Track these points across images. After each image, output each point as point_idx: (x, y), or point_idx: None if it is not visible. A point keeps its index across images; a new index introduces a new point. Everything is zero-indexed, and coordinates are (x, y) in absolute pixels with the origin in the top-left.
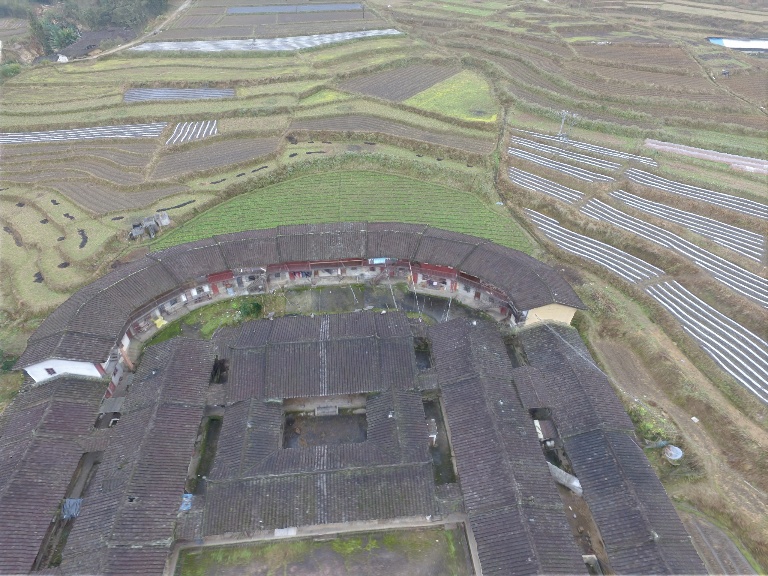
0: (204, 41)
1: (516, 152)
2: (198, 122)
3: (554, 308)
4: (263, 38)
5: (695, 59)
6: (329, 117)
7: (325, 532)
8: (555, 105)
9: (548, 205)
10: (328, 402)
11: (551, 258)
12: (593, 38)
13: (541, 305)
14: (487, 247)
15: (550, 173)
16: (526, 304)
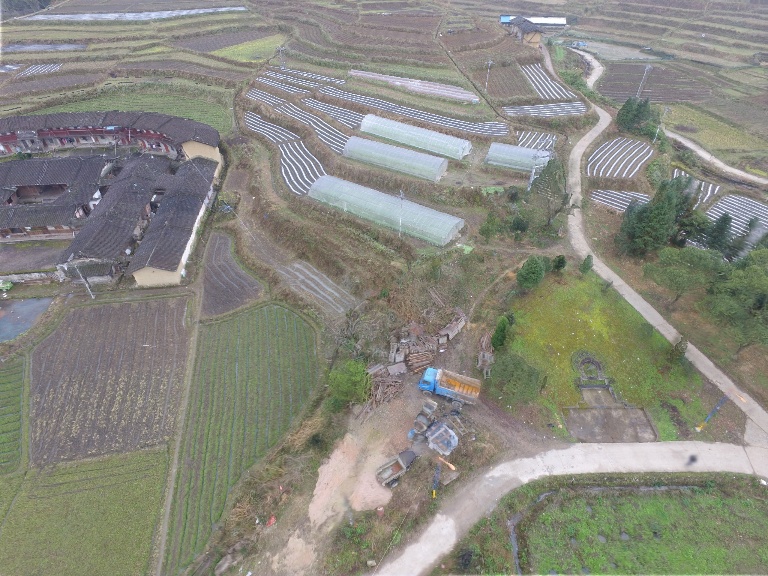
0: (84, 14)
1: (261, 79)
2: (48, 65)
3: (198, 146)
4: (132, 12)
5: (440, 23)
6: (149, 62)
7: (14, 240)
8: (311, 52)
9: (258, 107)
10: (51, 197)
11: (236, 133)
12: (384, 11)
13: (184, 142)
14: (181, 120)
15: (273, 90)
16: (177, 142)
